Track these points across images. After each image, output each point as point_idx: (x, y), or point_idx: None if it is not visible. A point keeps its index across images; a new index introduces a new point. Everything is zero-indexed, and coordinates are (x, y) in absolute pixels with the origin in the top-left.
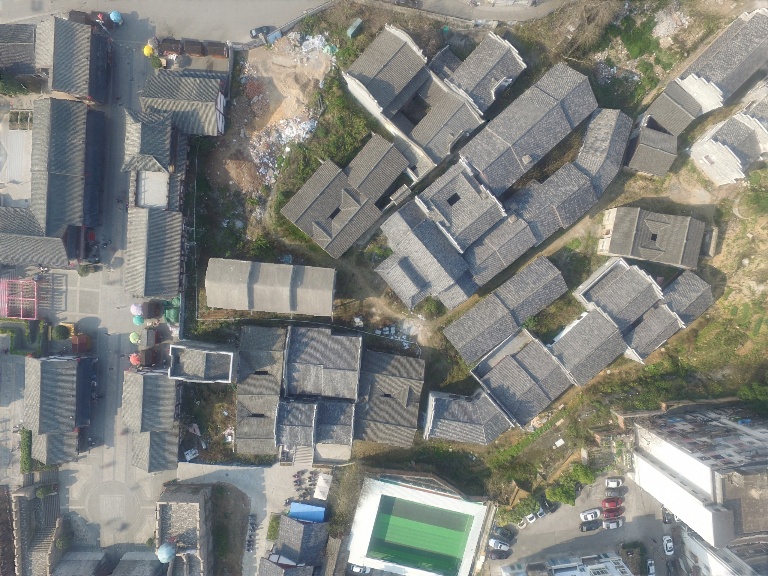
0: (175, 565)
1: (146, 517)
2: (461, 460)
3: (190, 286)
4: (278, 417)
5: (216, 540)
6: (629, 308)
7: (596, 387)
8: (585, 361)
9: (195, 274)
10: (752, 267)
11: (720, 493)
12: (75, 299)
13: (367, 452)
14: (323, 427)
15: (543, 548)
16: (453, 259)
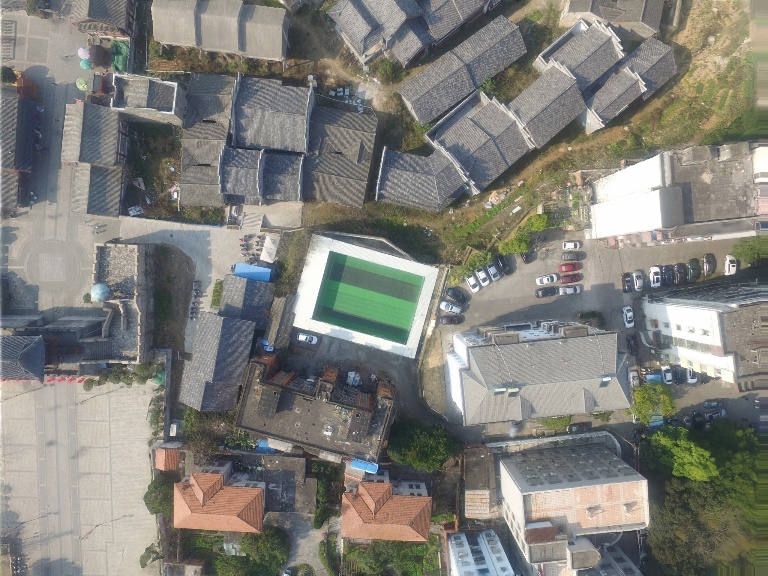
0: (113, 322)
1: (86, 279)
2: (416, 235)
3: (140, 35)
4: (223, 159)
5: (157, 302)
6: (588, 64)
7: (557, 163)
8: (542, 115)
9: (146, 23)
10: (718, 45)
11: (669, 174)
12: (23, 47)
13: (318, 221)
14: (270, 178)
15: (497, 316)
16: (407, 1)
